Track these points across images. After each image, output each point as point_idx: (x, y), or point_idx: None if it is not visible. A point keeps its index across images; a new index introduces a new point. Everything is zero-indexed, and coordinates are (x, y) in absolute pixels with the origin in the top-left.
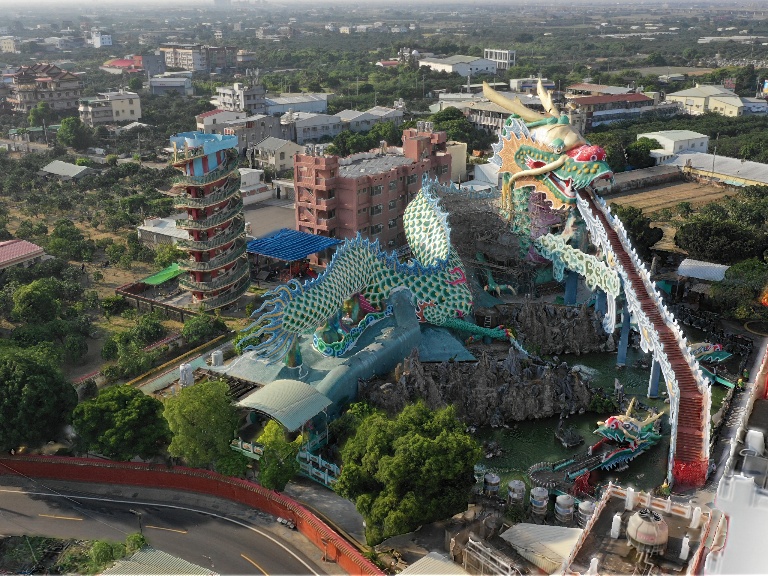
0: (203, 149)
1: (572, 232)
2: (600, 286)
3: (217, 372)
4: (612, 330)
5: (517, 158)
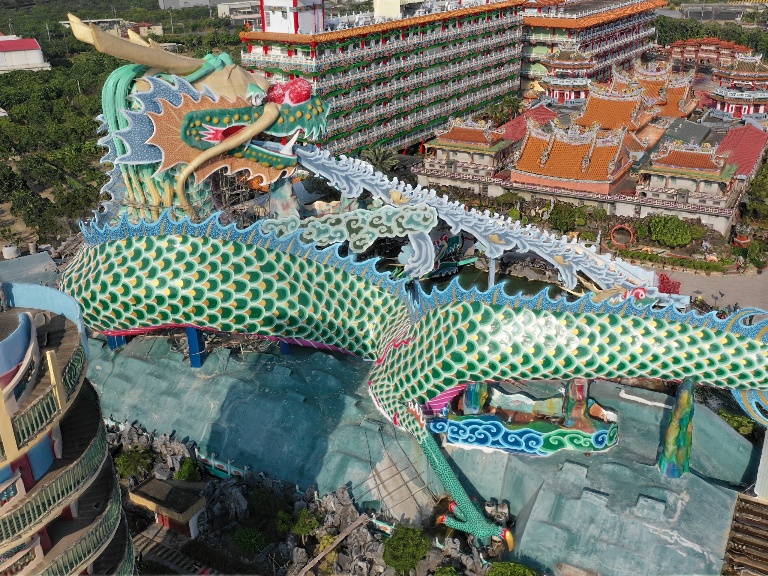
0: (81, 345)
1: (295, 203)
2: (389, 235)
3: (723, 574)
4: (432, 268)
5: (188, 136)
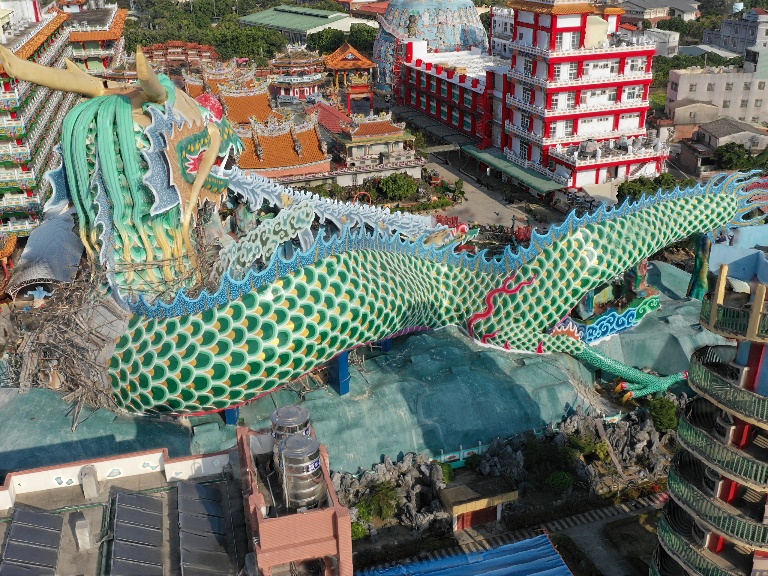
0: None
1: None
2: None
3: None
4: None
5: None
